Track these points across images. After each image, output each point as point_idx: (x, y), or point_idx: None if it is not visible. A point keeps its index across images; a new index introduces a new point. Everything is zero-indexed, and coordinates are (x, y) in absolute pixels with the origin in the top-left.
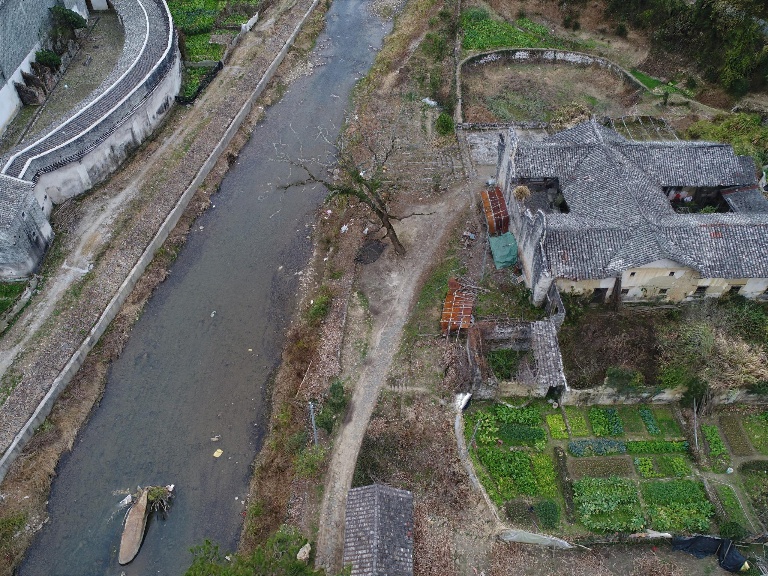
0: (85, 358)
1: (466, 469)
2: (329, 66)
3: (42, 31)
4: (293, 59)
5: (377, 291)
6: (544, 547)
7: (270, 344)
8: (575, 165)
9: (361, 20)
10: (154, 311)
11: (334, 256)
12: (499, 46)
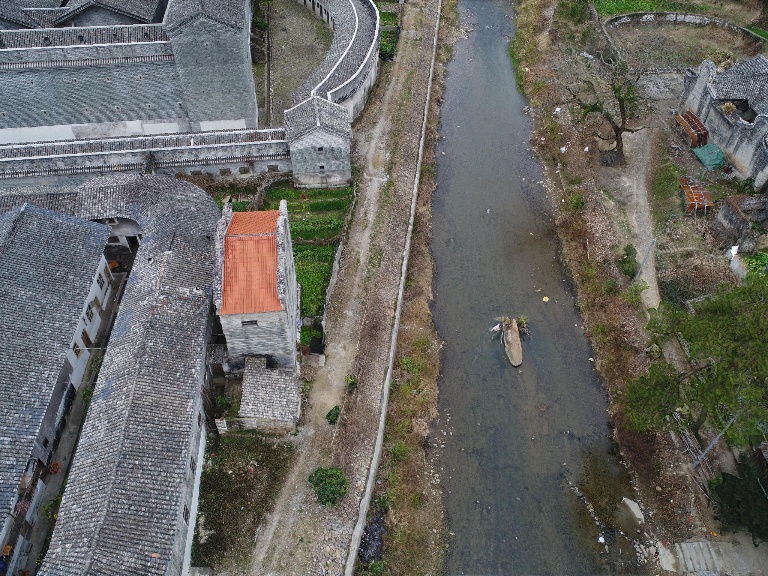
0: (411, 241)
1: None
2: (479, 31)
3: (249, 2)
4: (447, 26)
5: (617, 190)
6: None
7: (545, 230)
8: (759, 89)
9: None
10: (440, 211)
11: (564, 169)
12: (624, 11)
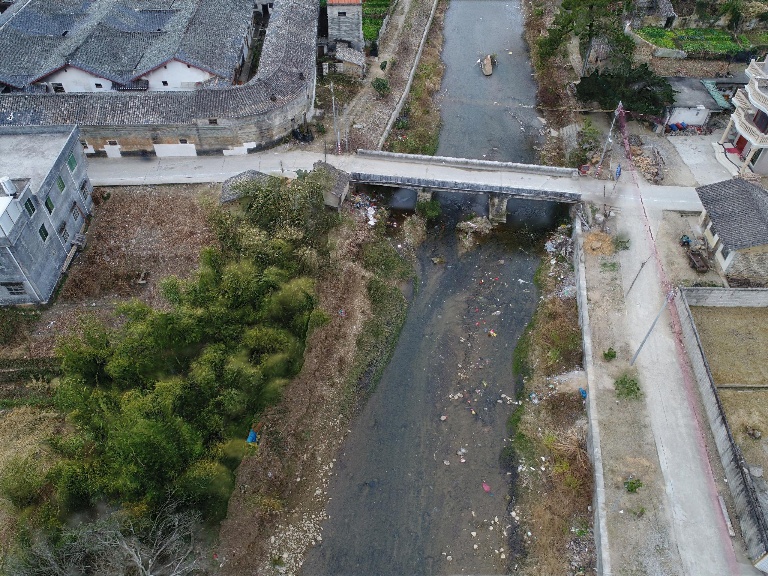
0: (430, 27)
1: (634, 41)
2: None
3: None
4: None
5: None
6: (673, 58)
7: (516, 27)
8: None
9: None
10: (450, 18)
11: (535, 1)
12: None
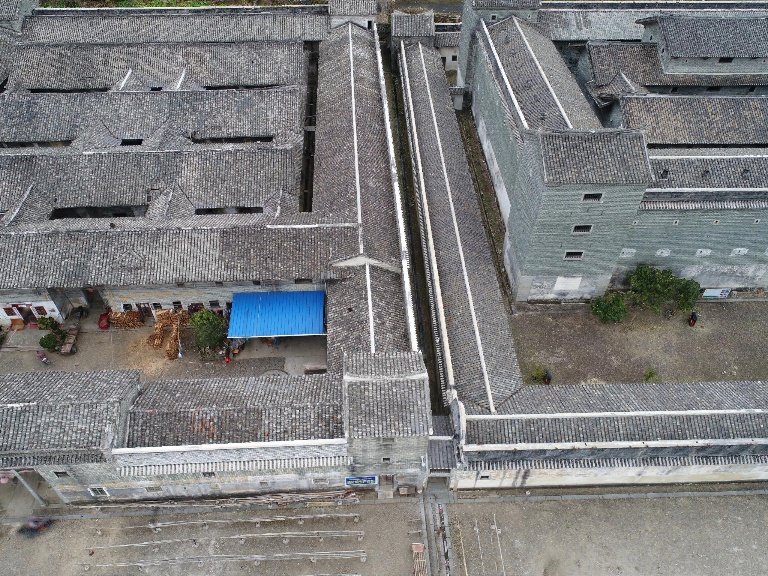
0: None
1: None
2: None
3: None
4: None
5: None
6: None
7: None
8: None
9: (410, 3)
10: None
11: None
12: None
